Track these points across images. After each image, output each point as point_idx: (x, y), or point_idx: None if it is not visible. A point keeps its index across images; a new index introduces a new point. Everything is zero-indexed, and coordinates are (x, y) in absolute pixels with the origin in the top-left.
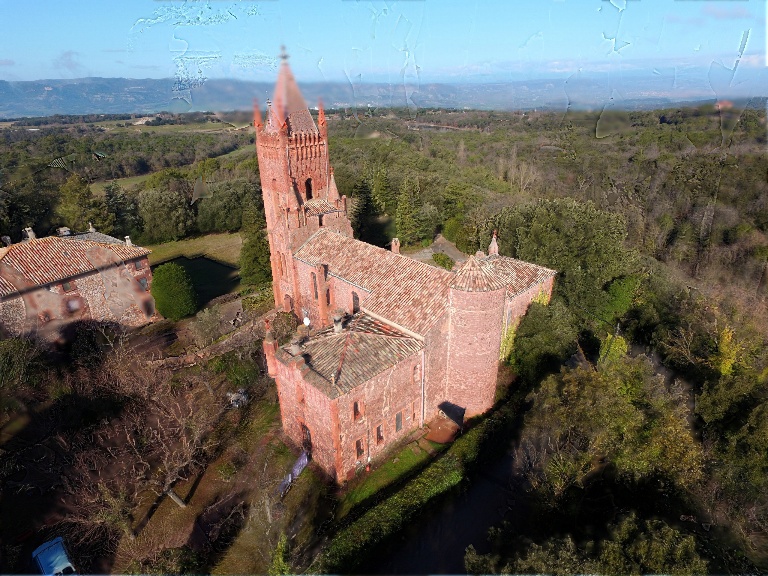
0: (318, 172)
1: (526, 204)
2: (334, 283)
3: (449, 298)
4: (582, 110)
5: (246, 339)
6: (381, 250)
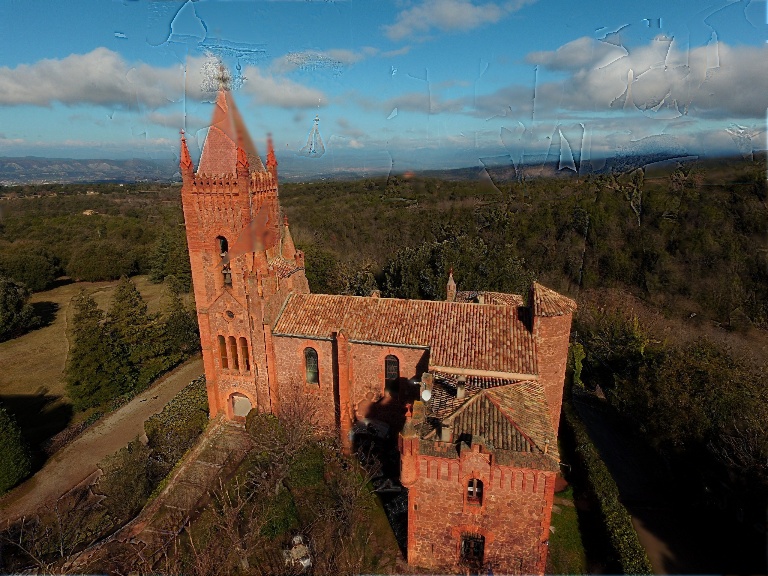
0: None
1: None
2: (352, 352)
3: (535, 328)
4: (403, 167)
5: (196, 474)
6: (400, 300)
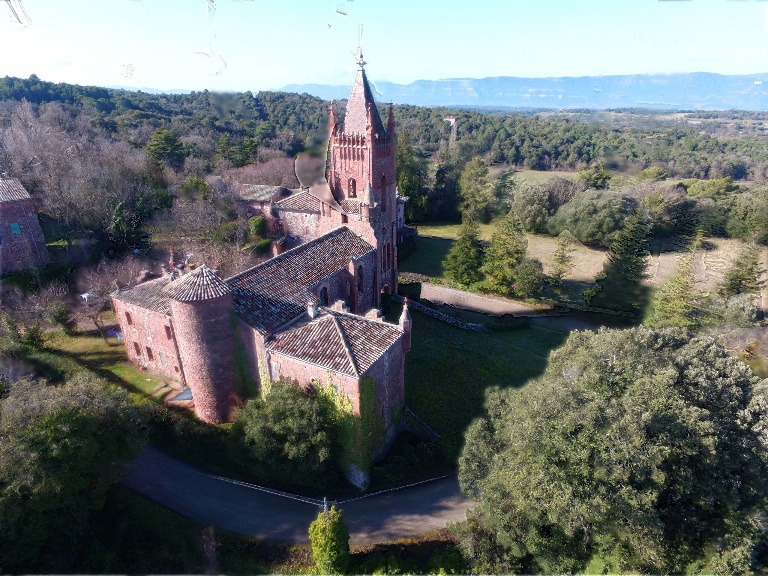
0: (361, 174)
1: (669, 333)
2: None
3: None
4: None
5: None
6: None
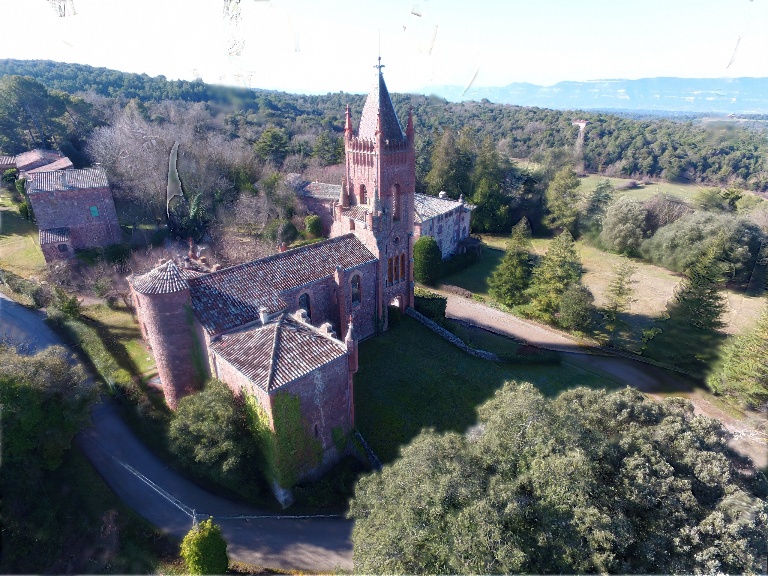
0: (371, 181)
1: None
2: None
3: None
4: None
5: None
6: None
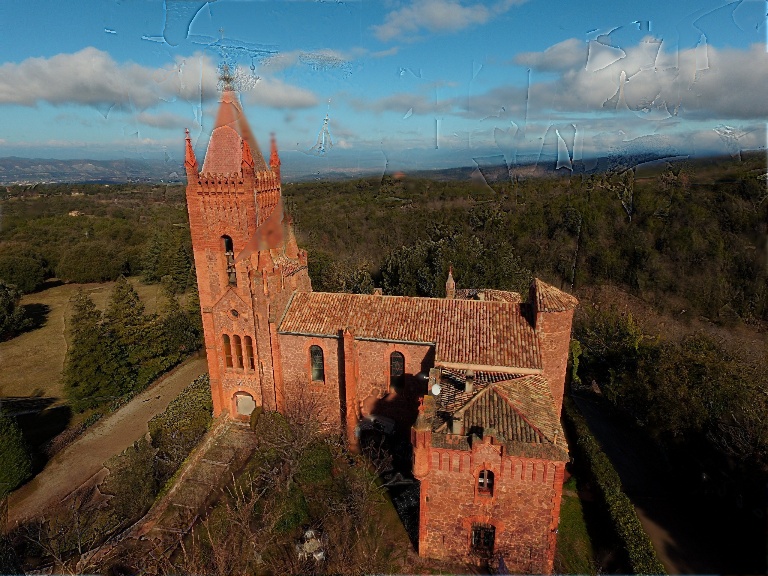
0: None
1: None
2: (358, 349)
3: (538, 324)
4: (398, 167)
5: (202, 472)
6: (404, 298)
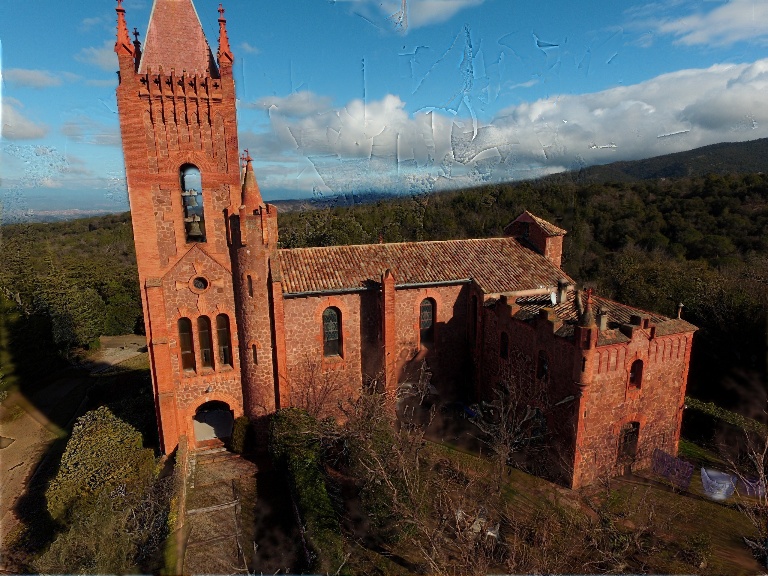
0: None
1: None
2: None
3: (547, 249)
4: None
5: (202, 527)
6: (407, 244)
